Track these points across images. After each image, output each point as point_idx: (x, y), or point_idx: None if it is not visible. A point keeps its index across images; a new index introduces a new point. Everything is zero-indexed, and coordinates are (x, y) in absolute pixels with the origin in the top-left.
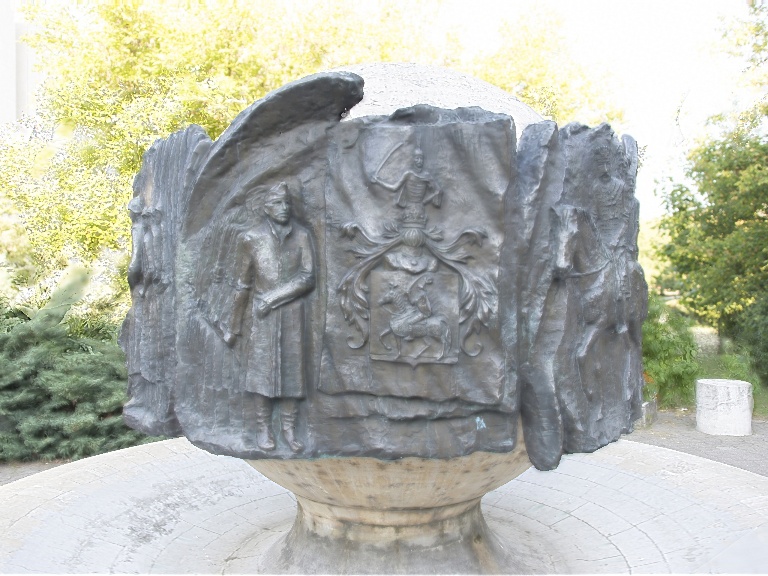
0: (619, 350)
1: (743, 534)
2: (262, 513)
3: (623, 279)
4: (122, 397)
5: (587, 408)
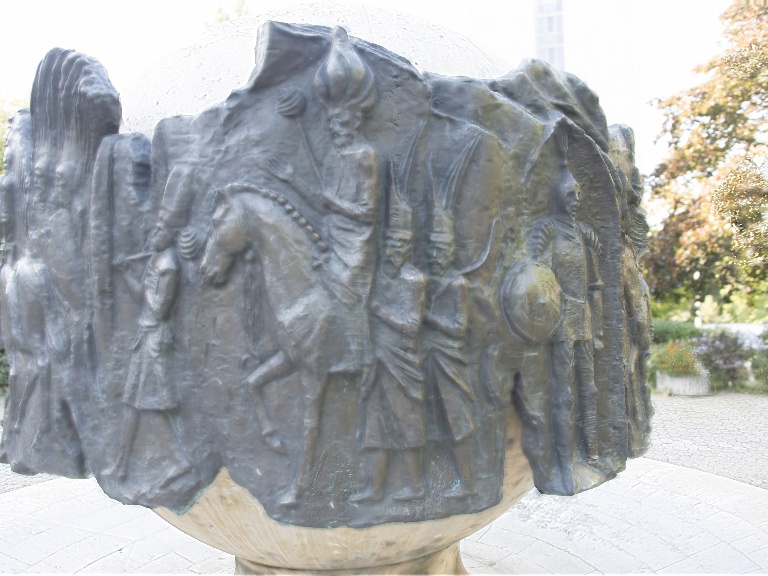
0: None
1: None
2: (536, 560)
3: None
4: None
5: None
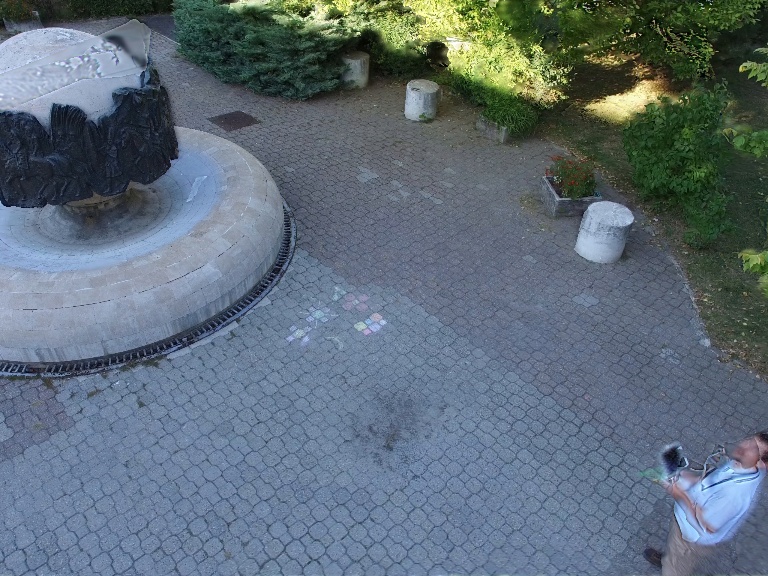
0: (32, 183)
1: None
2: None
3: (20, 164)
4: (263, 67)
5: (17, 196)
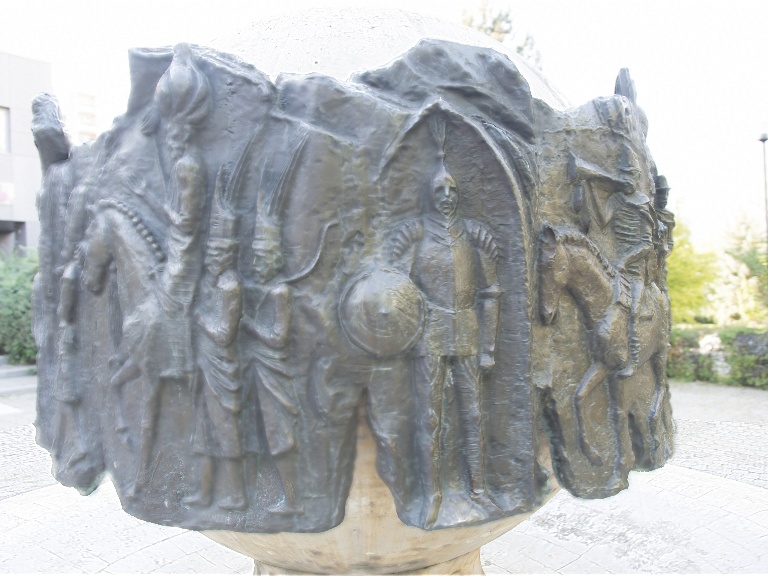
0: None
1: None
2: None
3: None
4: None
5: None
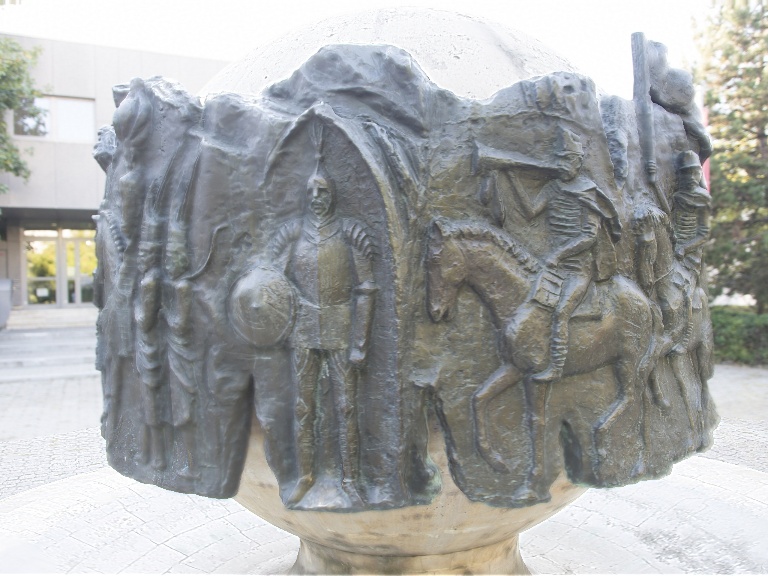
0: None
1: None
2: None
3: None
4: None
5: None
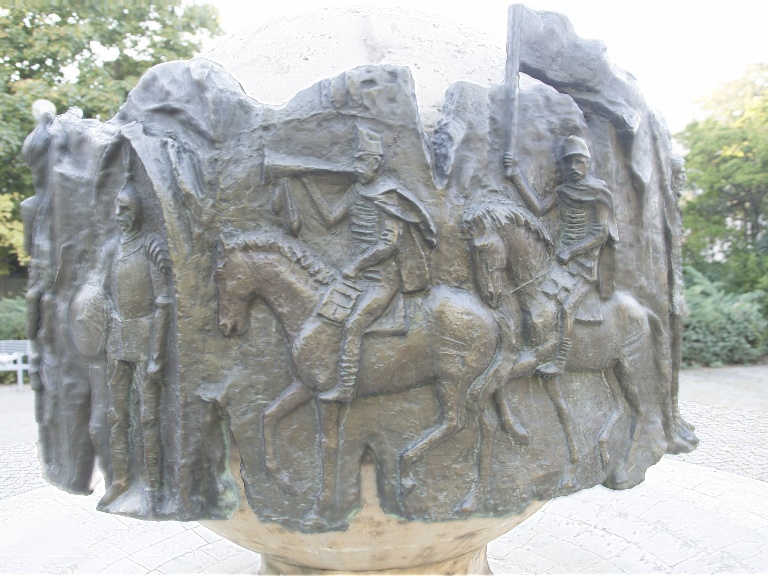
0: None
1: (5, 556)
2: None
3: None
4: None
5: None
